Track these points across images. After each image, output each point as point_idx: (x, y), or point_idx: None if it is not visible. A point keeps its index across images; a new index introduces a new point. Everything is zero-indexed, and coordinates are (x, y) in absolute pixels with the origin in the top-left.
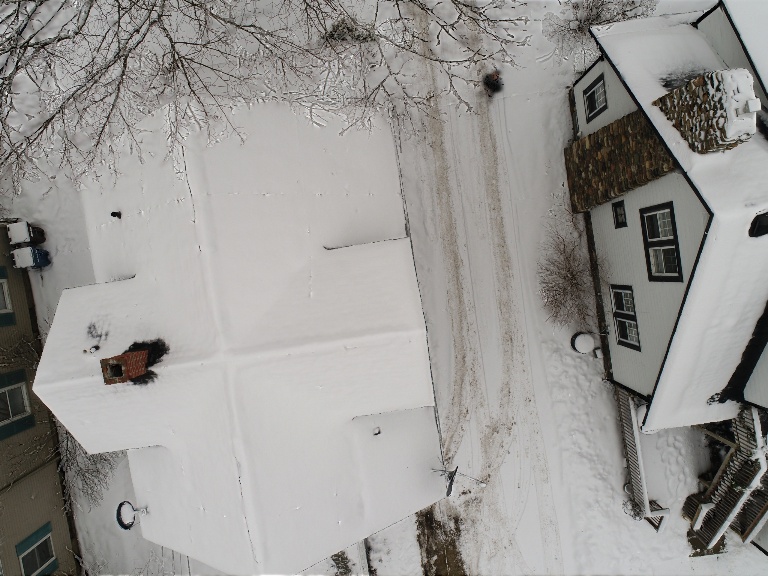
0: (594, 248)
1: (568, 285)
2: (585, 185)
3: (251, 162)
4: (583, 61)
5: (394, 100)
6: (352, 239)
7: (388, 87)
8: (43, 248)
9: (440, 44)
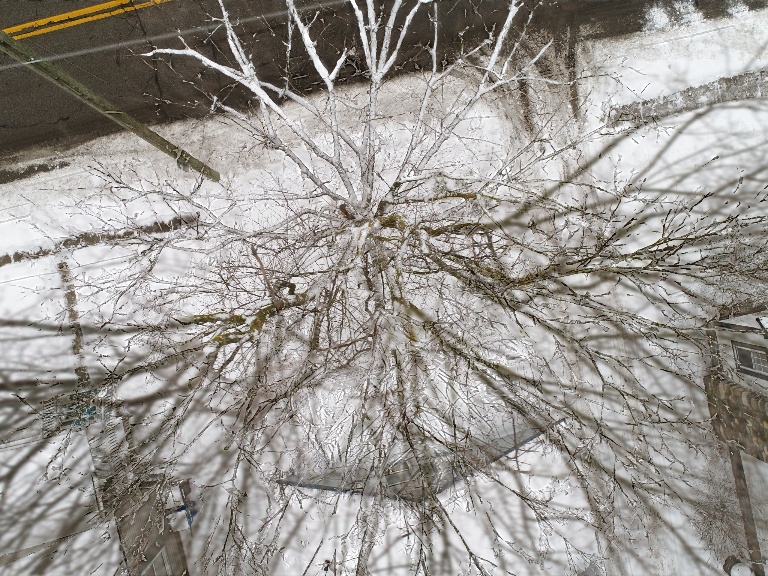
0: (743, 478)
1: (718, 513)
2: (739, 432)
3: (480, 543)
4: (721, 298)
5: (532, 340)
6: (559, 573)
7: (526, 329)
8: (190, 499)
9: (573, 281)
